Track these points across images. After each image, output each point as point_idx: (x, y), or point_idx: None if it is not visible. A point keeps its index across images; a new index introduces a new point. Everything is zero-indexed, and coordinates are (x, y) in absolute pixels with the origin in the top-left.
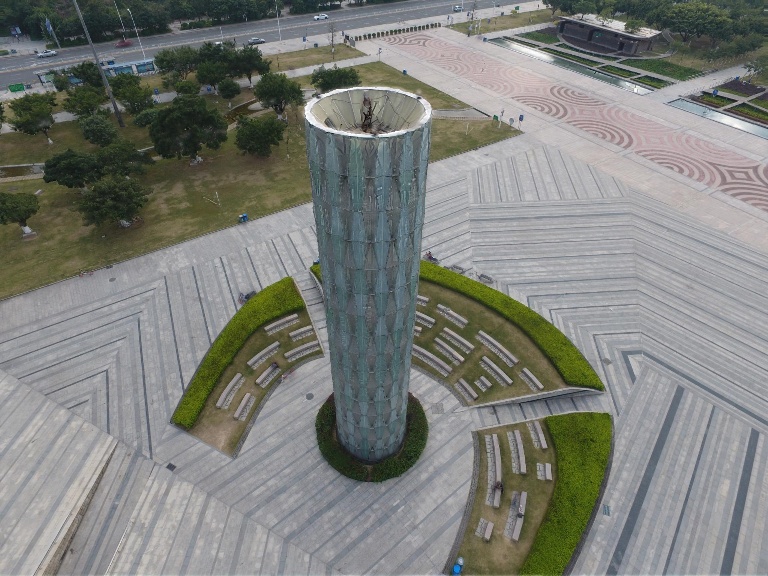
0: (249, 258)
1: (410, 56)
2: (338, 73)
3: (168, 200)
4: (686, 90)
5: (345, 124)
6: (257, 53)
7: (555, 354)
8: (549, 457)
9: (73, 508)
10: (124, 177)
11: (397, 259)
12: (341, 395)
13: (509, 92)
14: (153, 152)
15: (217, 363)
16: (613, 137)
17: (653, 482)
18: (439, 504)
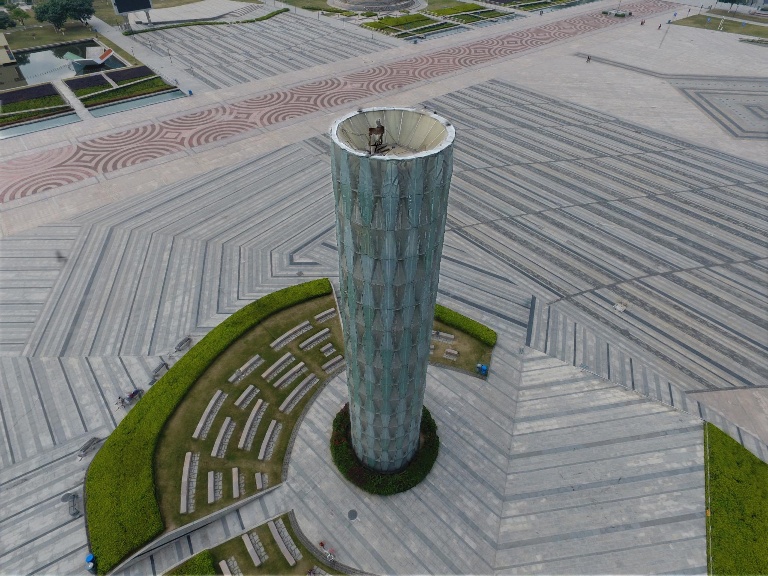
0: None
1: None
2: None
3: None
4: None
5: None
6: None
7: (302, 295)
8: None
9: None
10: None
11: None
12: (417, 405)
13: None
14: None
15: None
16: None
17: None
18: (440, 383)
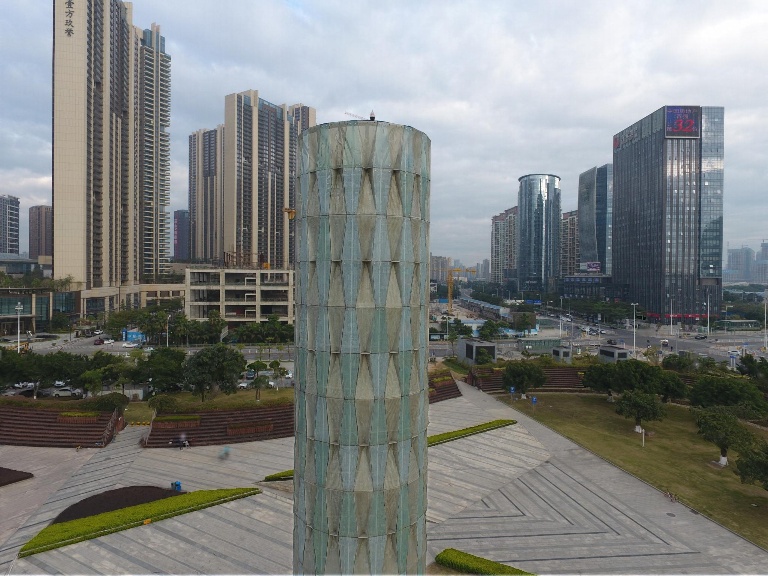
0: None
1: None
2: None
3: None
4: None
5: None
6: None
7: None
8: None
9: None
10: None
11: None
12: None
13: None
14: None
15: None
16: None
17: None
18: None
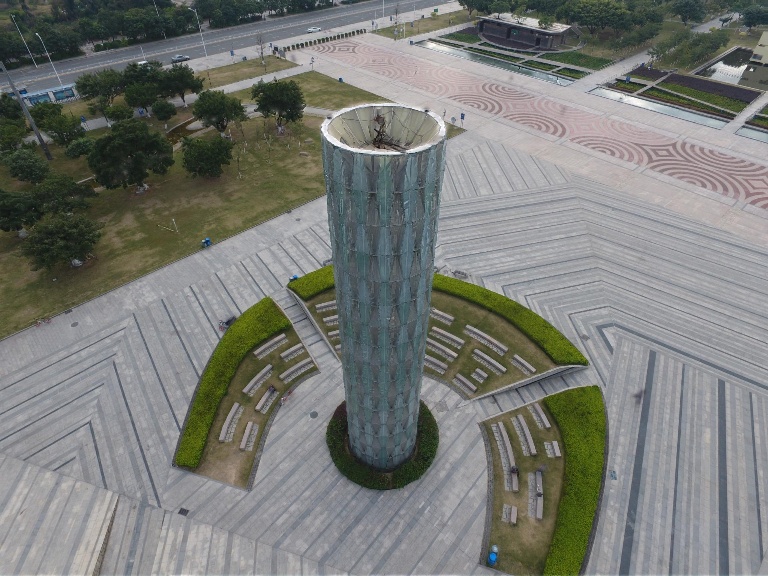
0: (221, 283)
1: (342, 63)
2: (279, 86)
3: (120, 233)
4: (602, 79)
5: (357, 142)
6: (188, 71)
7: (540, 337)
8: (554, 435)
9: (84, 575)
10: (65, 213)
11: (419, 268)
12: (359, 408)
13: (445, 92)
14: (92, 183)
15: (211, 396)
16: (548, 127)
17: (647, 442)
18: (462, 498)
